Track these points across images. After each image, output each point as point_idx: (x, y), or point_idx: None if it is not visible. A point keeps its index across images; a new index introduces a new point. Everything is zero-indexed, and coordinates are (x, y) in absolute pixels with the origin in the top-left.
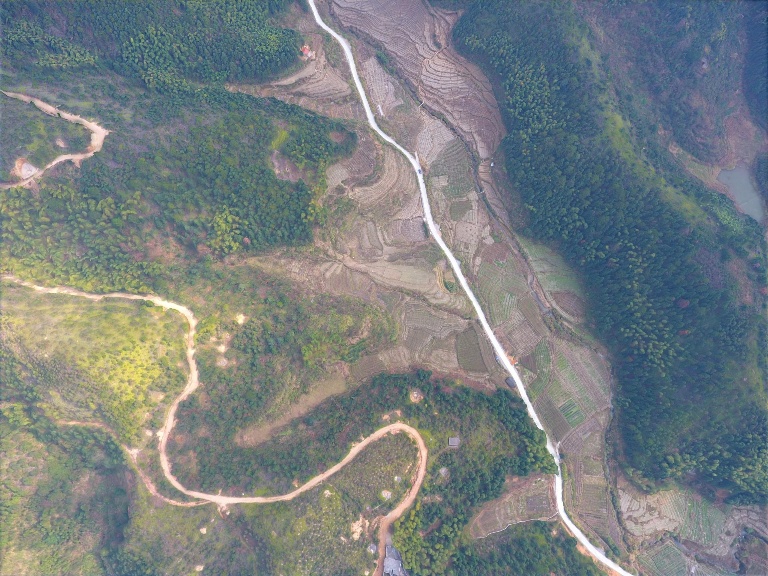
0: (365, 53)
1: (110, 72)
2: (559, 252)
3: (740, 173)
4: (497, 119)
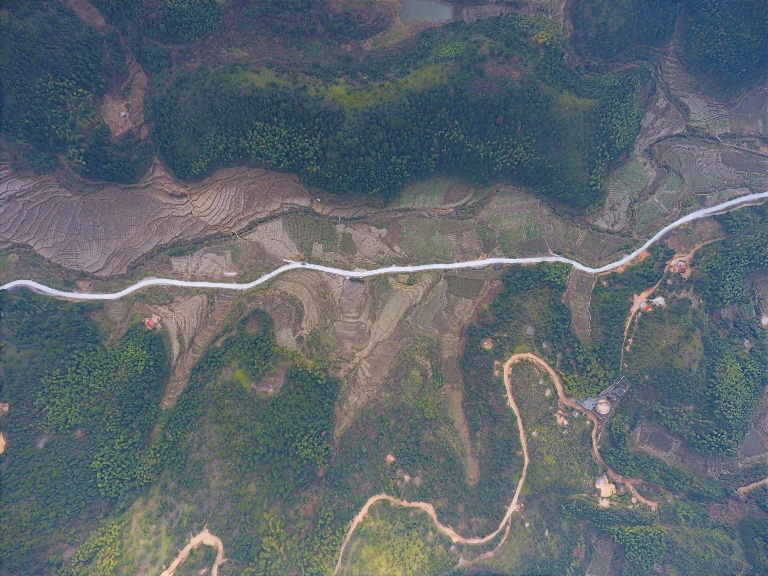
0: (164, 265)
1: (130, 513)
2: (414, 182)
3: (407, 3)
4: (278, 176)
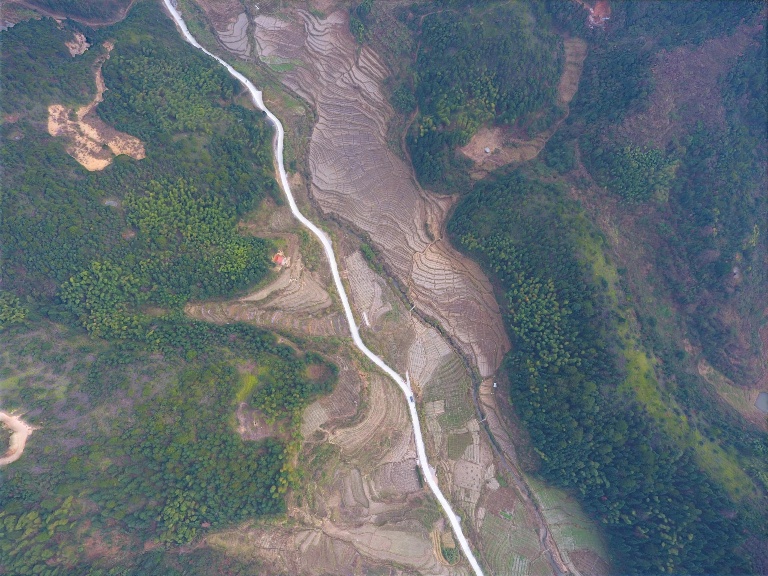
0: (348, 246)
1: (44, 325)
2: (575, 499)
3: None
4: (499, 327)
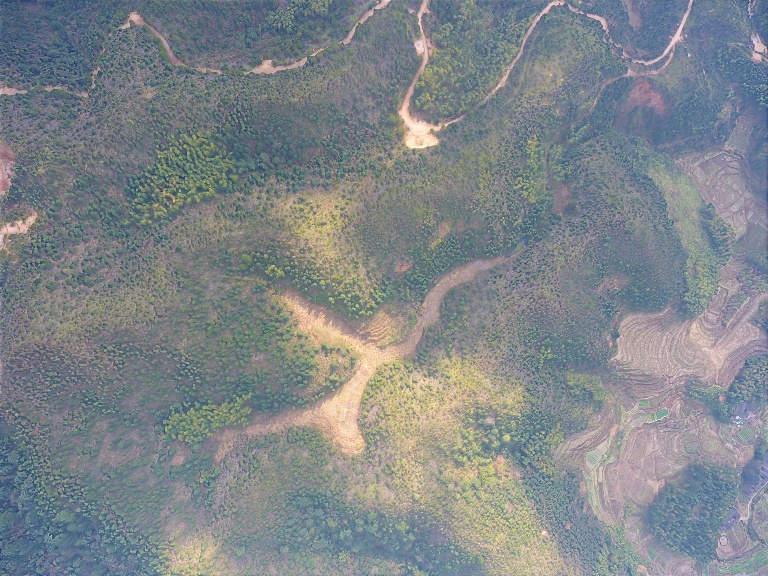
0: None
1: None
2: None
3: None
4: None
